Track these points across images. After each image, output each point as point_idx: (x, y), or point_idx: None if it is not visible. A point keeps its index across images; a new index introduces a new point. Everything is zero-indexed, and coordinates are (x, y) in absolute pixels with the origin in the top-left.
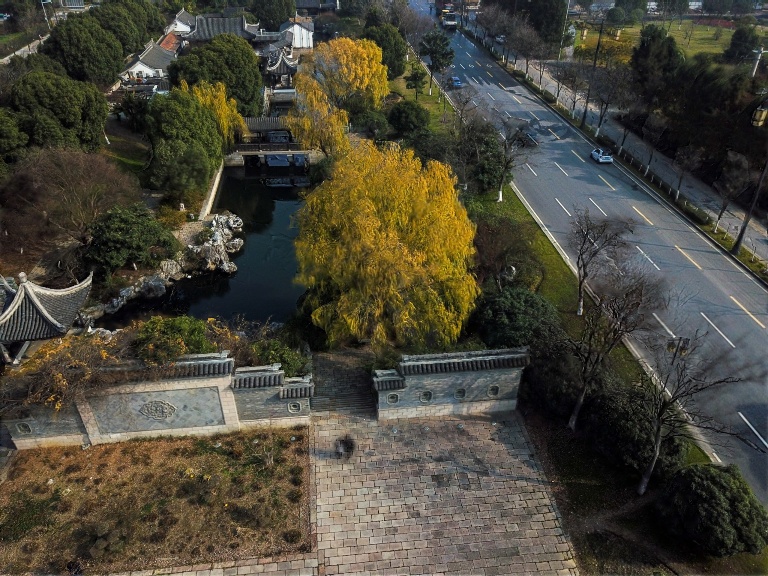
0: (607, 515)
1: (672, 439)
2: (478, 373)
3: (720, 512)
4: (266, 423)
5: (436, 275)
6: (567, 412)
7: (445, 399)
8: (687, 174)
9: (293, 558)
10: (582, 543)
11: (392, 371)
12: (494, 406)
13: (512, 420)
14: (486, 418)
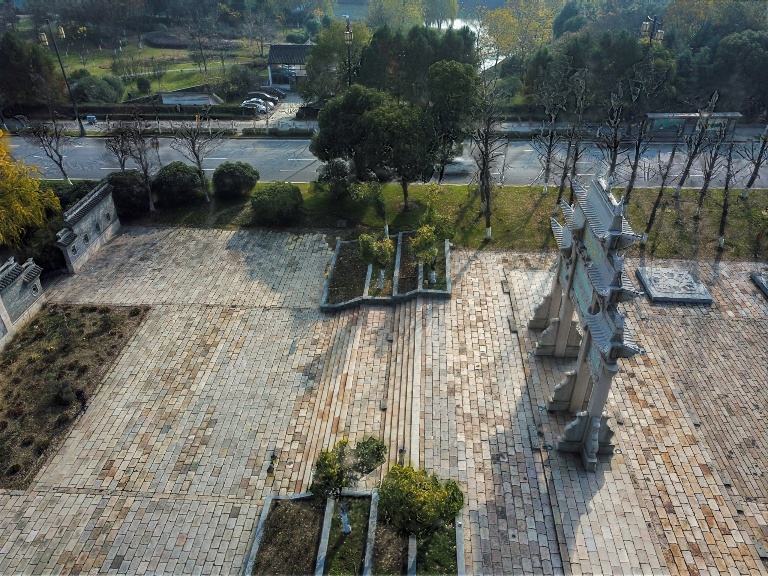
0: (211, 214)
1: (198, 171)
2: (98, 207)
3: (242, 169)
4: (26, 316)
5: (6, 182)
6: (147, 202)
7: (94, 236)
8: (1, 109)
9: (150, 313)
10: (218, 226)
11: (64, 229)
12: (113, 229)
13: (127, 229)
14: (116, 236)
